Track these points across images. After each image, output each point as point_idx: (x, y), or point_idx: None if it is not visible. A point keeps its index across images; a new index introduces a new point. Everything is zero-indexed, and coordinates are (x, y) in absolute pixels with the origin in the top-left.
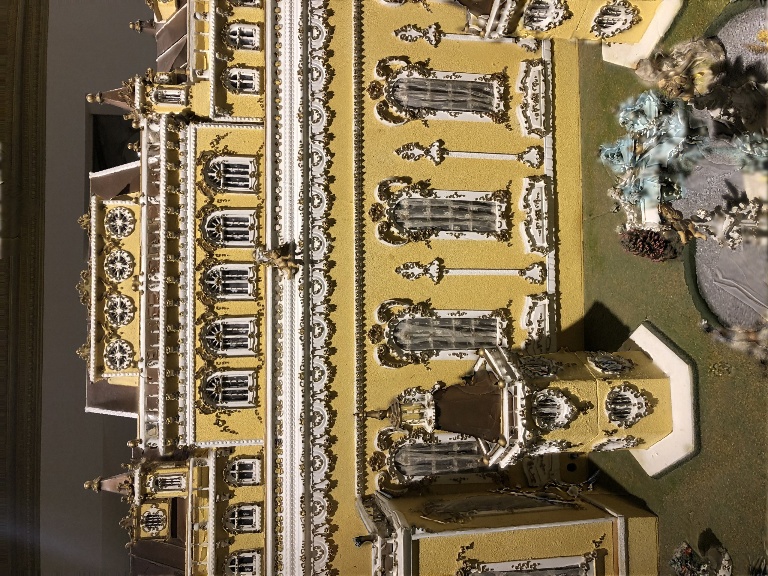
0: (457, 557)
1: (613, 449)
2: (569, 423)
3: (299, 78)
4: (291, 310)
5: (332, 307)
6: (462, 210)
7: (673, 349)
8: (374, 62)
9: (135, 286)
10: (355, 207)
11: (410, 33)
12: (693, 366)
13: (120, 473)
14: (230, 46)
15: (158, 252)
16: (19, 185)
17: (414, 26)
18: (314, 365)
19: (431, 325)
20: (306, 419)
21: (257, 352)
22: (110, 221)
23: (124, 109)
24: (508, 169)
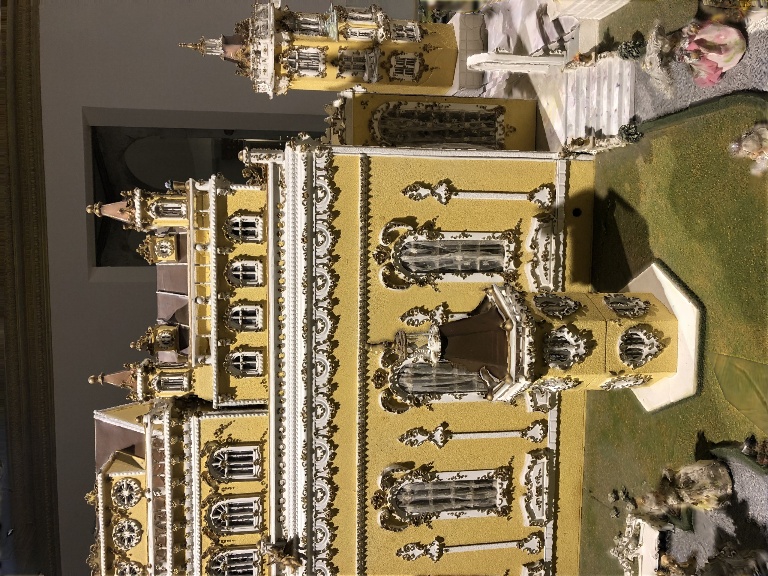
0: None
1: None
2: None
3: (303, 378)
4: None
5: None
6: (464, 490)
7: None
8: None
9: None
10: (358, 498)
11: (417, 317)
12: None
13: None
14: (233, 330)
15: (165, 540)
16: (27, 523)
17: (421, 308)
18: None
19: None
20: None
21: None
22: (117, 492)
23: (127, 392)
24: (511, 445)
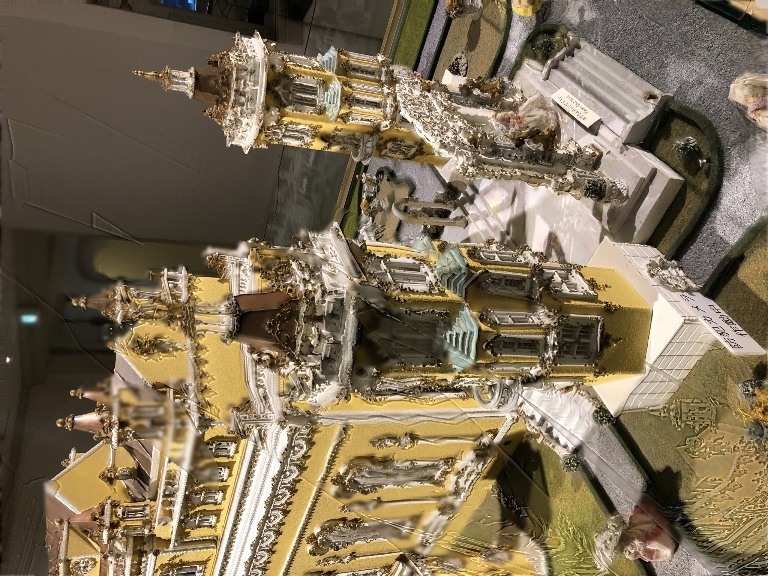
0: None
1: None
2: None
3: (251, 548)
4: None
5: None
6: None
7: None
8: (317, 524)
9: None
10: None
11: None
12: None
13: None
14: (194, 505)
15: None
16: None
17: None
18: None
19: None
20: None
21: None
22: (75, 565)
23: None
24: None
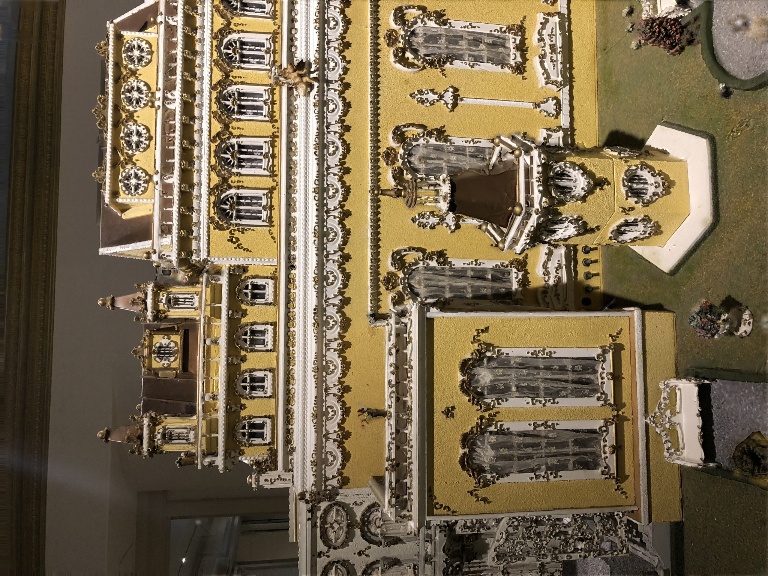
0: (472, 339)
1: (630, 239)
2: (586, 198)
3: None
4: (306, 127)
5: (347, 127)
6: (476, 41)
7: (690, 132)
8: None
9: (151, 102)
10: (370, 30)
11: None
12: (711, 140)
13: (133, 293)
14: None
15: (175, 72)
16: None
17: None
18: (328, 182)
19: (445, 151)
20: (320, 233)
21: (271, 172)
22: (128, 51)
23: None
24: (522, 4)
